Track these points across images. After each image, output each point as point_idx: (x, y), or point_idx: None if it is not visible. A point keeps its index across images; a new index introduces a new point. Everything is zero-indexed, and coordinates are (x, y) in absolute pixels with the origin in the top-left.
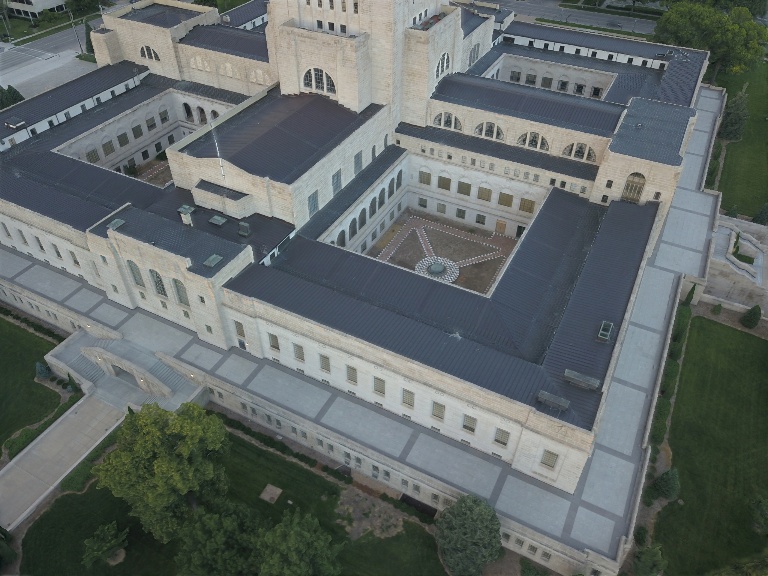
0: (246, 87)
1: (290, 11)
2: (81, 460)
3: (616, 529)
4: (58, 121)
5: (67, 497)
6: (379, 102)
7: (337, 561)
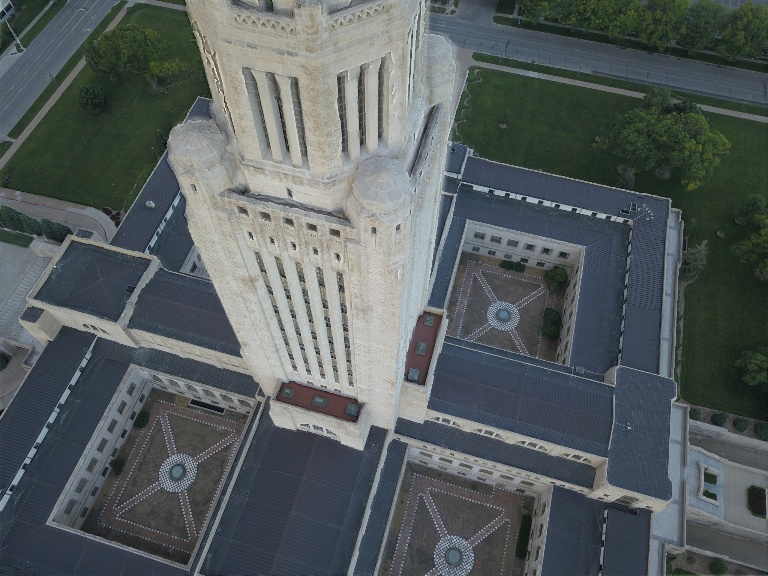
0: (219, 364)
1: (276, 375)
2: None
3: None
4: (30, 458)
5: None
6: (379, 426)
7: None
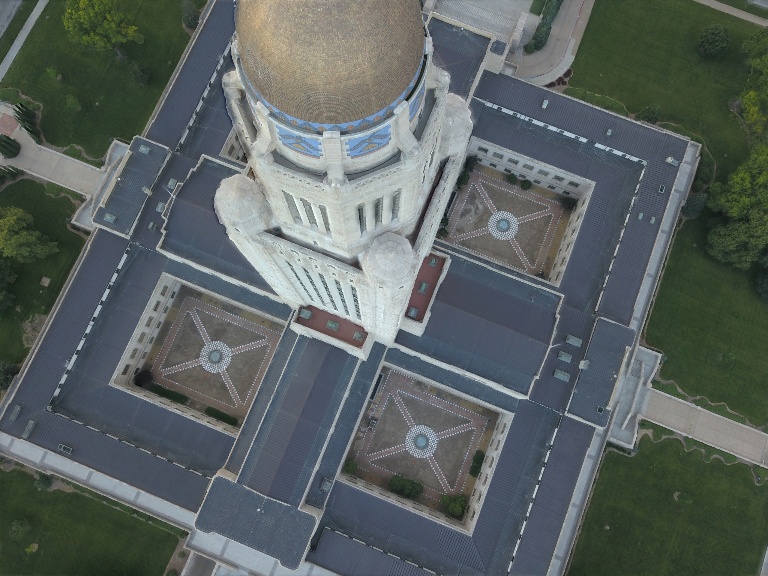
0: None
1: None
2: (61, 186)
3: (3, 446)
4: None
5: (43, 188)
6: None
7: None
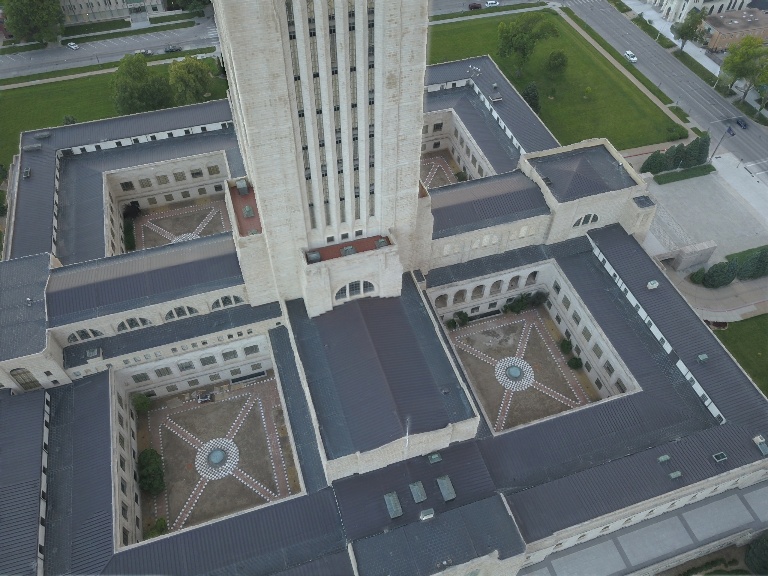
0: None
1: None
2: None
3: None
4: None
5: None
6: None
7: (122, 115)
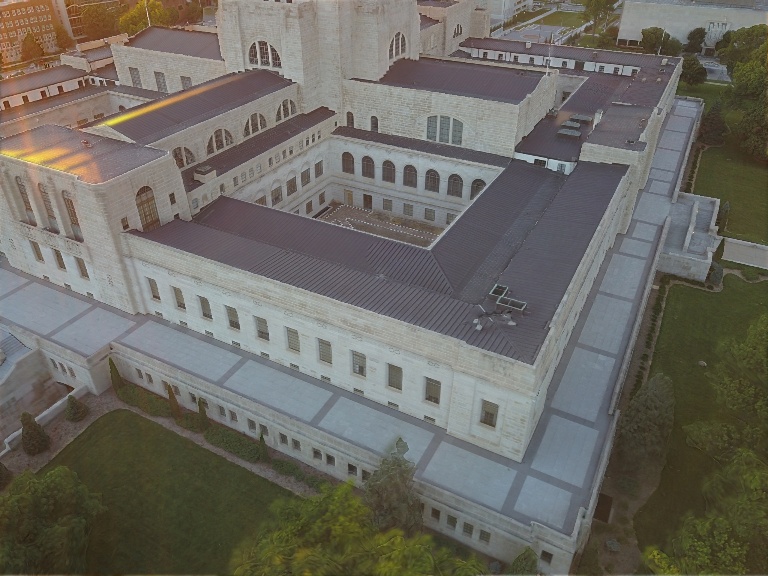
0: None
1: None
2: None
3: None
4: None
5: None
6: None
7: None
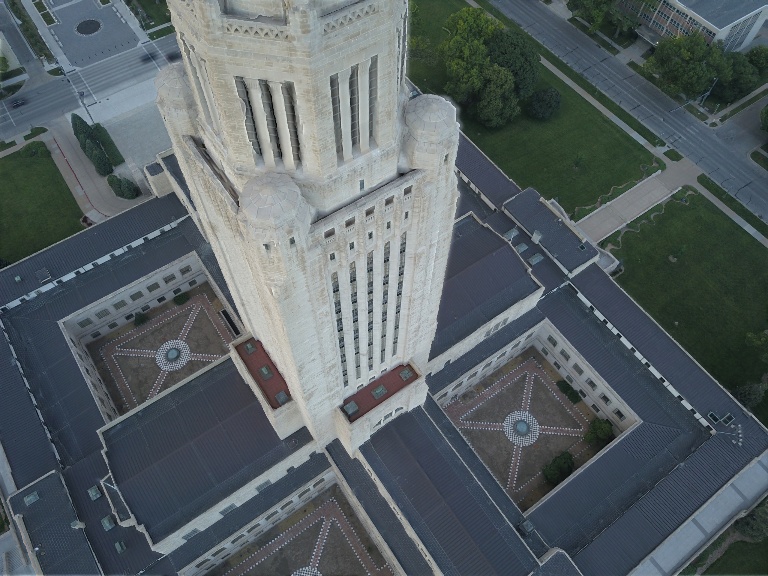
0: None
1: None
2: None
3: None
4: (85, 270)
5: None
6: (309, 431)
7: None
